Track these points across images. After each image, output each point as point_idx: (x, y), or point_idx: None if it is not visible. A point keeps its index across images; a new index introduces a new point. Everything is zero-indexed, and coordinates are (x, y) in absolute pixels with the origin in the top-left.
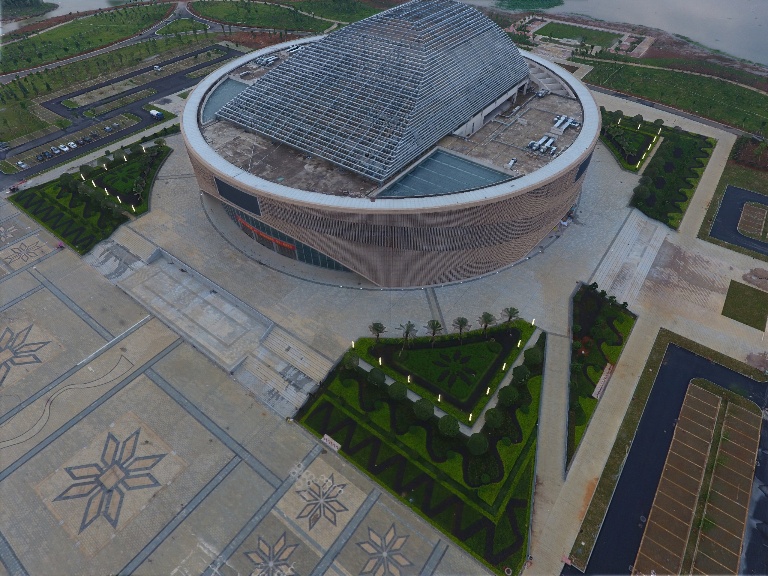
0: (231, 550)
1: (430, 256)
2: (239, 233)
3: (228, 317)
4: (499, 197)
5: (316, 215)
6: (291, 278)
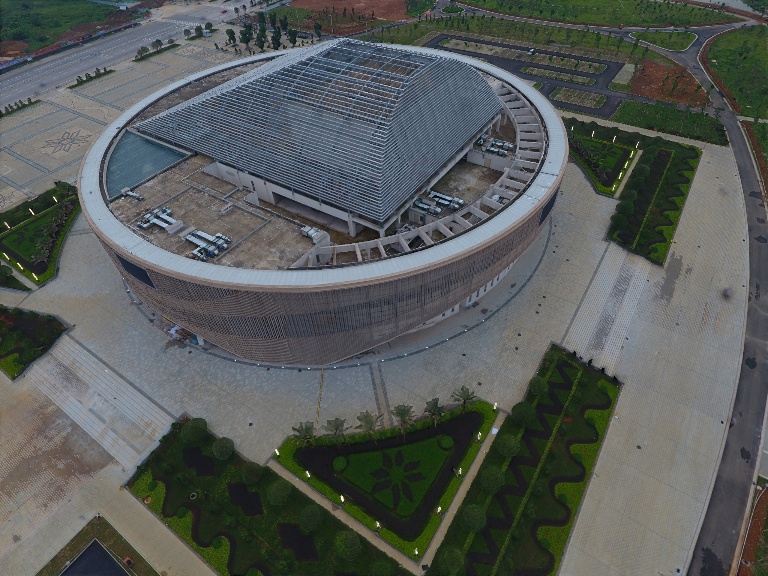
0: (1, 178)
1: None
2: None
3: None
4: (78, 184)
5: None
6: None
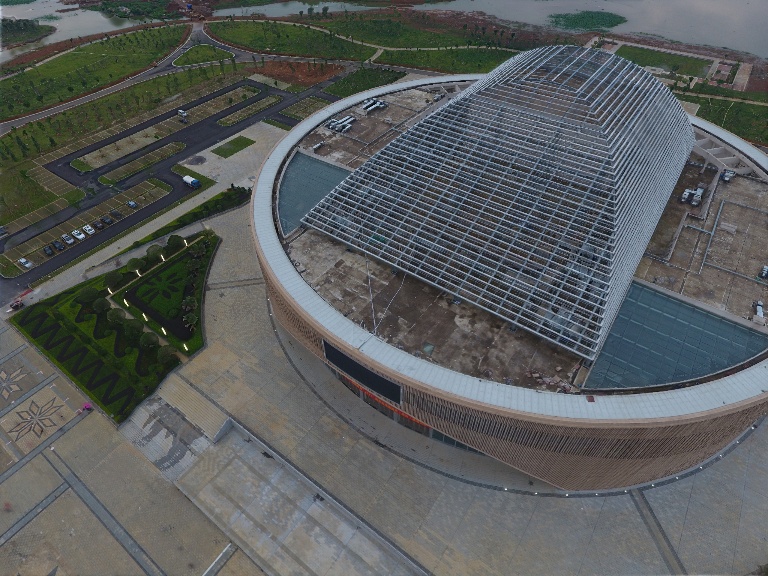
0: None
1: (655, 461)
2: (336, 385)
3: (350, 552)
4: None
5: (501, 422)
6: (429, 473)
